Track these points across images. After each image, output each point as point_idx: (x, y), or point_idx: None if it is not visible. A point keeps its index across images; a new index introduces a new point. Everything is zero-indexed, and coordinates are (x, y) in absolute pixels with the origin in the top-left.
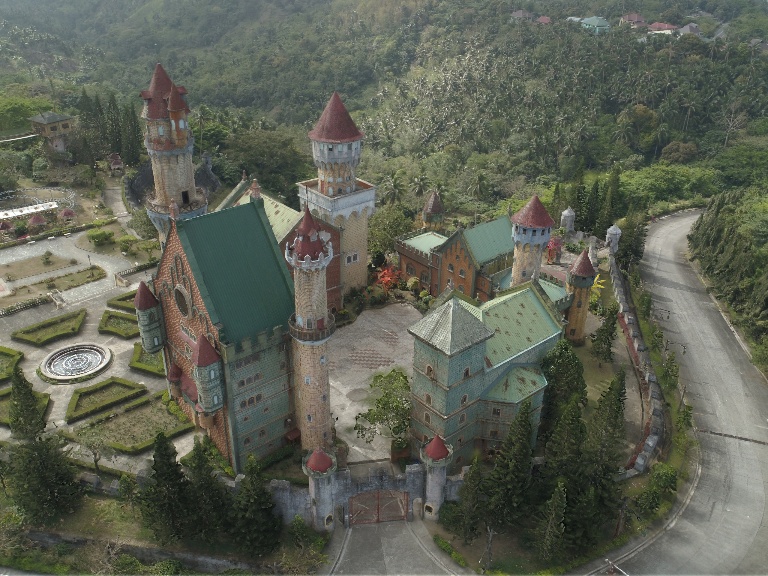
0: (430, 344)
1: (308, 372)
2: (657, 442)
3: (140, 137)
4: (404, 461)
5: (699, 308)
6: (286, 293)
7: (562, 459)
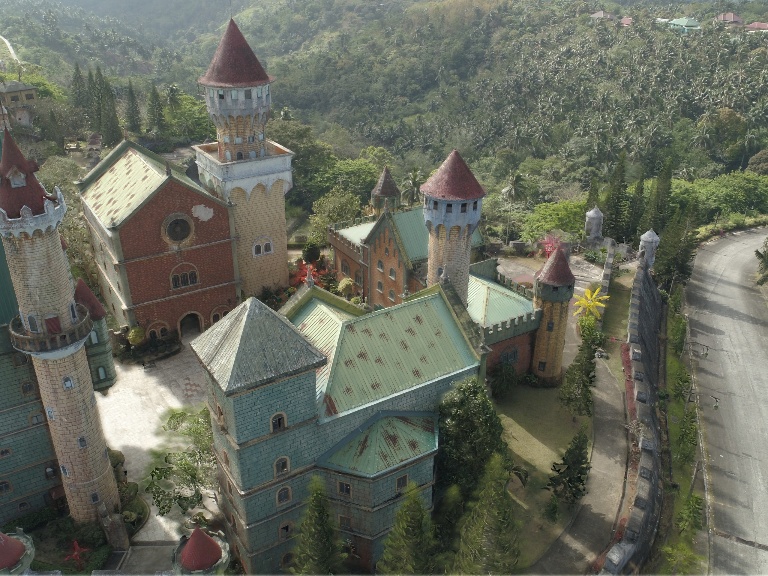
0: (207, 370)
1: (48, 400)
2: (633, 554)
3: (139, 120)
4: None
5: (760, 345)
6: None
7: None
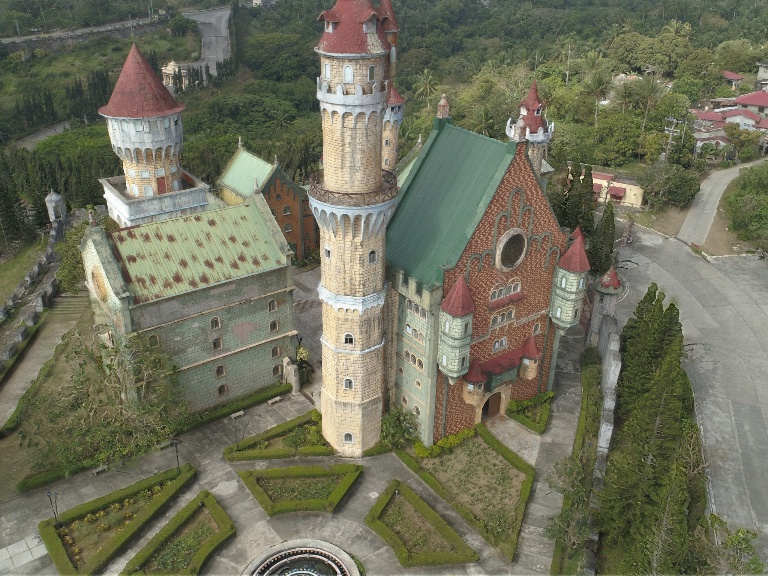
0: None
1: None
2: None
3: None
4: None
5: None
6: None
7: None
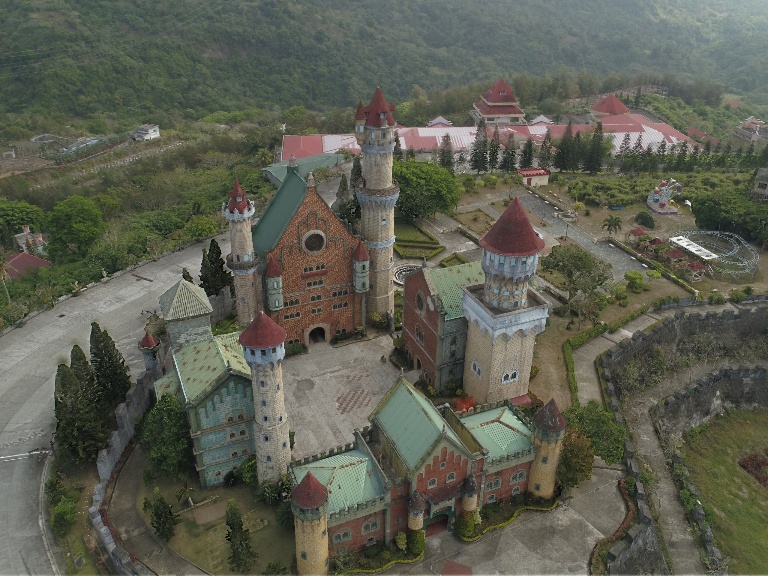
0: None
1: None
2: None
3: None
4: None
5: None
6: None
7: None
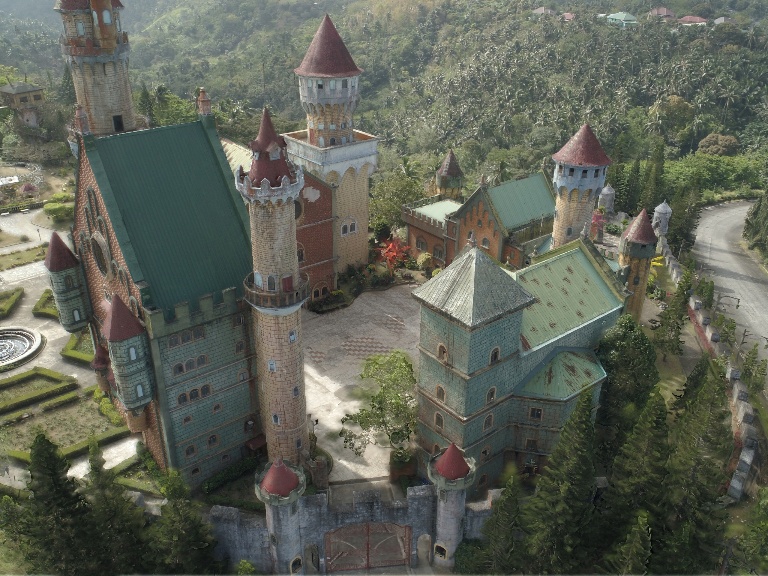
0: (443, 312)
1: (272, 354)
2: (753, 459)
3: None
4: (407, 481)
5: (767, 300)
6: (244, 245)
7: (639, 481)
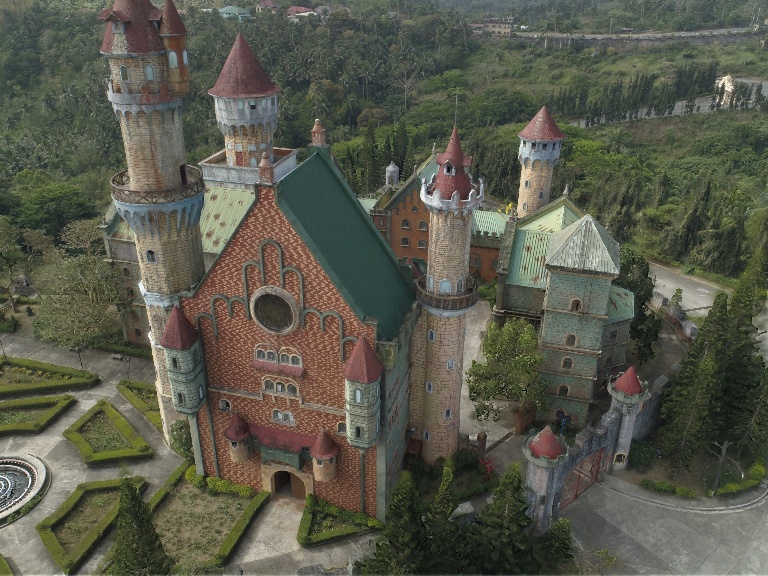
0: (587, 270)
1: (452, 353)
2: None
3: None
4: (535, 427)
5: None
6: (390, 264)
7: (737, 347)
